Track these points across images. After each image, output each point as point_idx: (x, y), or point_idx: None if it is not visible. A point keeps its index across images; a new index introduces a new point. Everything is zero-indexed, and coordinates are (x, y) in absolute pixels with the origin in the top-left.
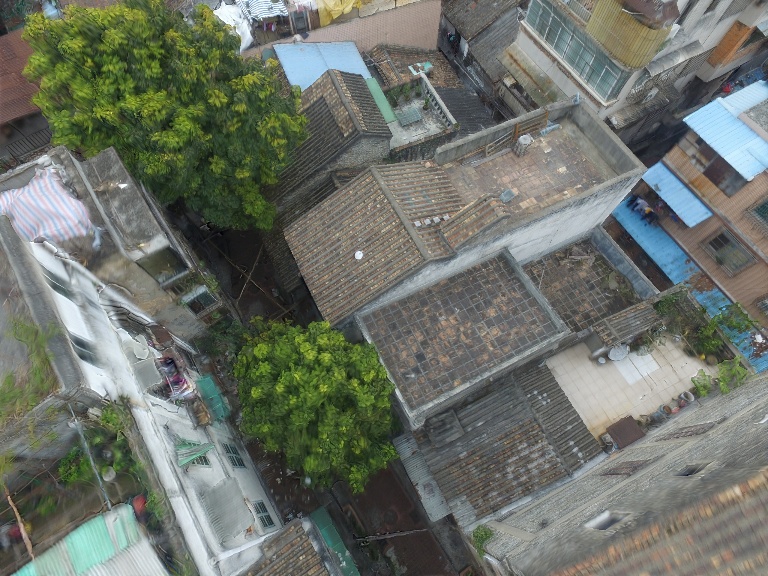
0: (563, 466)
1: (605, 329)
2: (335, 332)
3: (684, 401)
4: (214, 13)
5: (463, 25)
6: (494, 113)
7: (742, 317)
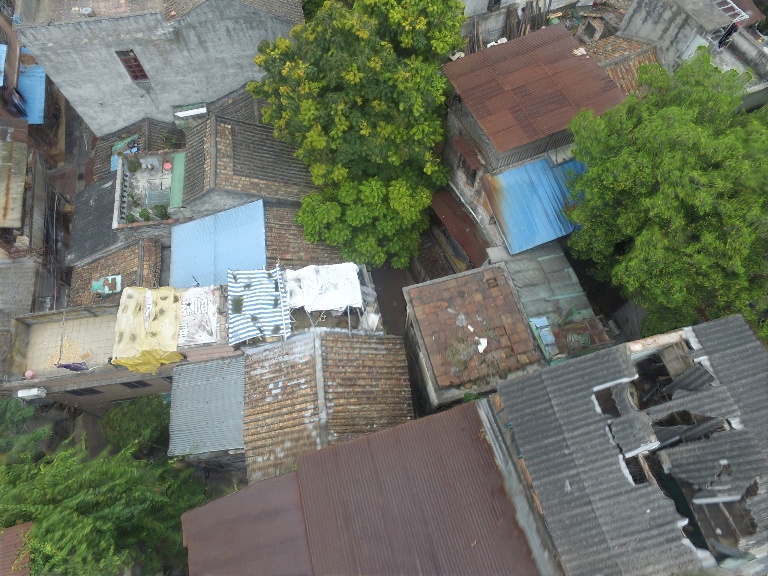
0: None
1: None
2: None
3: None
4: (324, 303)
5: None
6: (59, 280)
7: None
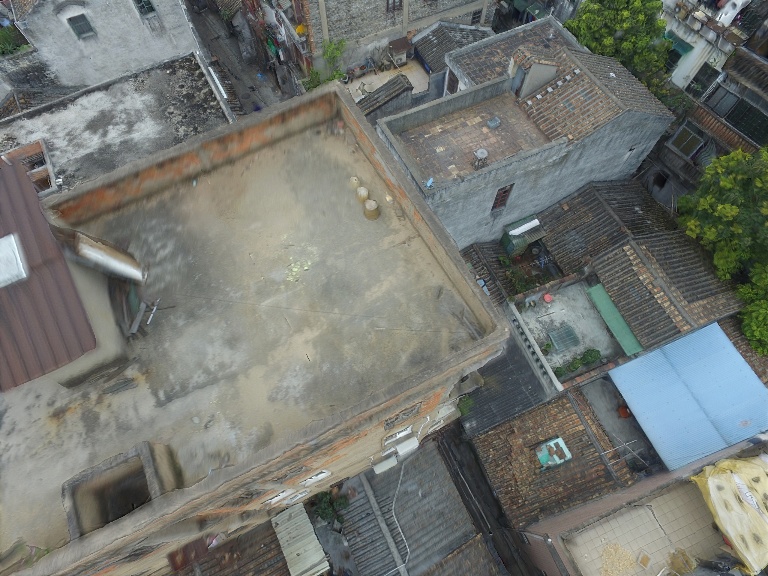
0: (444, 28)
1: (407, 82)
2: (611, 51)
3: (350, 73)
4: None
5: (491, 570)
6: None
7: (313, 75)
